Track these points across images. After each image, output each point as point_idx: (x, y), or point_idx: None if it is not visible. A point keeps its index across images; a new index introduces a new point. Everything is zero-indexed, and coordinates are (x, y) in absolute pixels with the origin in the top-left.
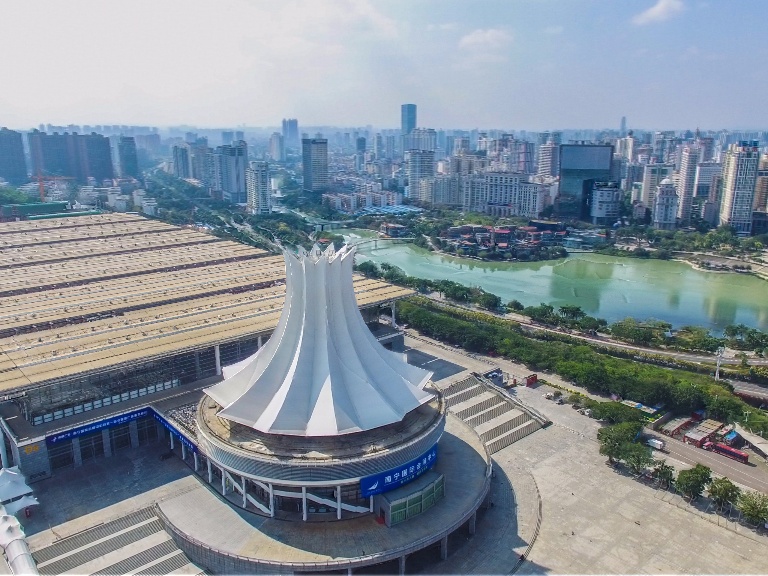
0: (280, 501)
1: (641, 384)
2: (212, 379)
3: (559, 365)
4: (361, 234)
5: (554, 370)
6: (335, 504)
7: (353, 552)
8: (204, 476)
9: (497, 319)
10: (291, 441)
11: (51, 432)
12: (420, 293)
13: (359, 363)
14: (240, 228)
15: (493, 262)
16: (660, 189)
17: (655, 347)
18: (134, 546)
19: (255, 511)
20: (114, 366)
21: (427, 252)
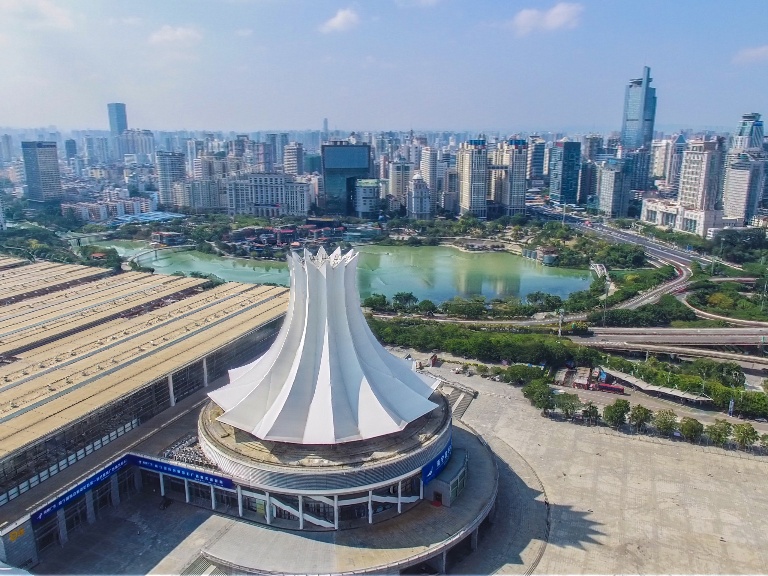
0: (338, 512)
1: (526, 347)
2: (170, 412)
3: (447, 344)
4: (125, 245)
5: (443, 349)
6: (395, 499)
7: (439, 536)
8: (228, 512)
9: None
10: (347, 448)
11: (34, 508)
12: None
13: None
14: None
15: None
16: (414, 184)
17: (485, 319)
18: None
19: (316, 529)
20: (92, 414)
21: (216, 258)
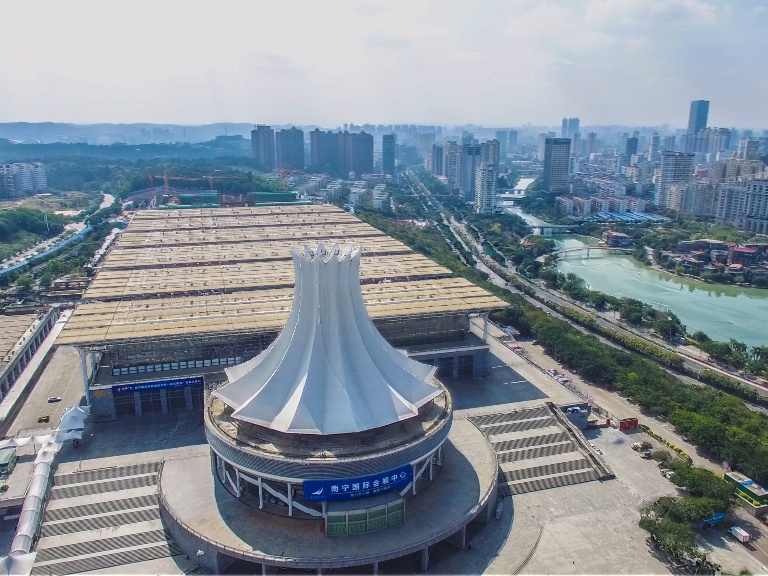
0: (249, 485)
1: (760, 456)
2: None
3: (676, 413)
4: (584, 241)
5: (669, 418)
6: (287, 500)
7: (274, 550)
8: None
9: (658, 350)
10: (259, 430)
11: (118, 383)
12: (593, 310)
13: (342, 366)
14: (455, 226)
15: (718, 285)
16: None
17: None
18: (127, 492)
19: (229, 488)
20: (174, 336)
21: (643, 266)
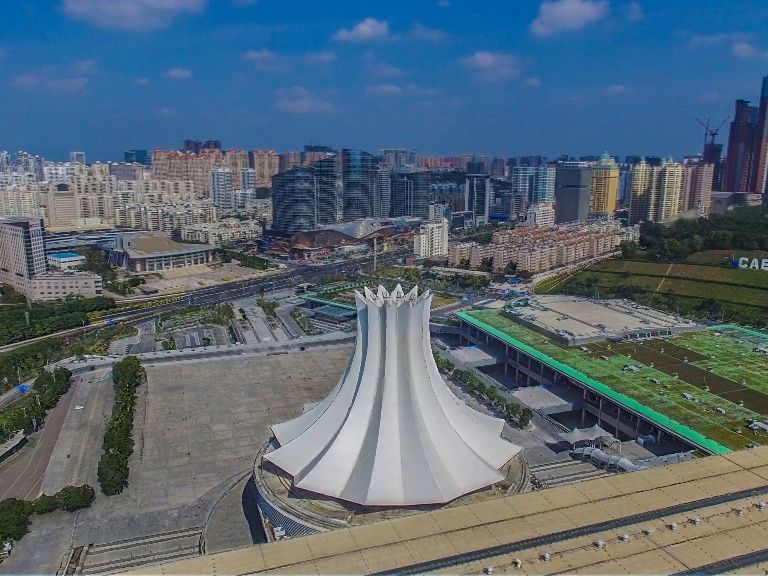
0: None
1: None
2: None
3: None
4: None
5: None
6: None
7: None
8: None
9: None
10: None
11: None
12: None
13: None
14: None
15: None
16: None
17: None
18: None
19: None
20: None
21: None
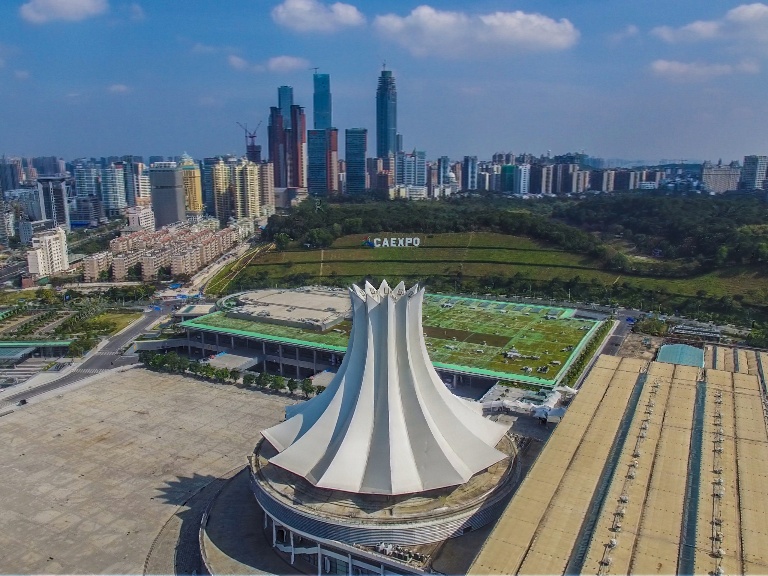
0: None
1: None
2: None
3: None
4: None
5: None
6: None
7: None
8: None
9: None
10: None
11: None
12: None
13: None
14: None
15: None
16: None
17: None
18: None
19: None
20: None
21: None
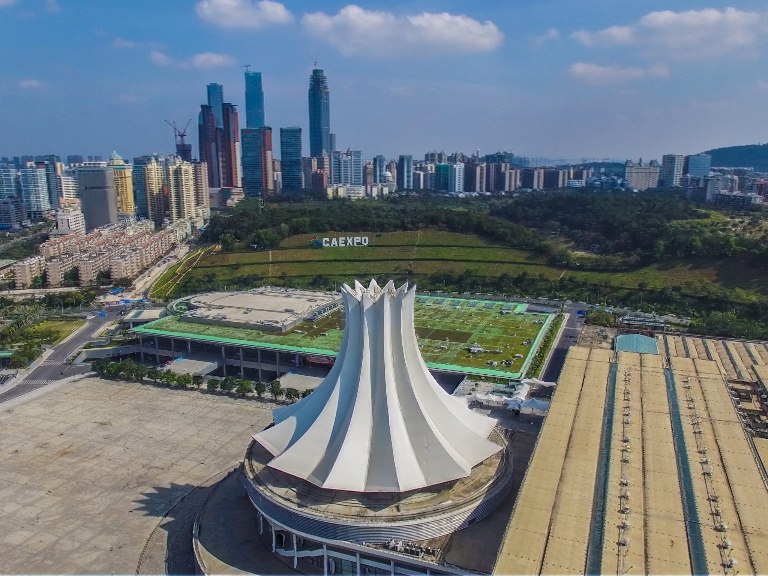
0: None
1: None
2: None
3: None
4: None
5: None
6: None
7: None
8: None
9: None
10: None
11: None
12: None
13: None
14: None
15: None
16: None
17: None
18: None
19: None
20: None
21: None
